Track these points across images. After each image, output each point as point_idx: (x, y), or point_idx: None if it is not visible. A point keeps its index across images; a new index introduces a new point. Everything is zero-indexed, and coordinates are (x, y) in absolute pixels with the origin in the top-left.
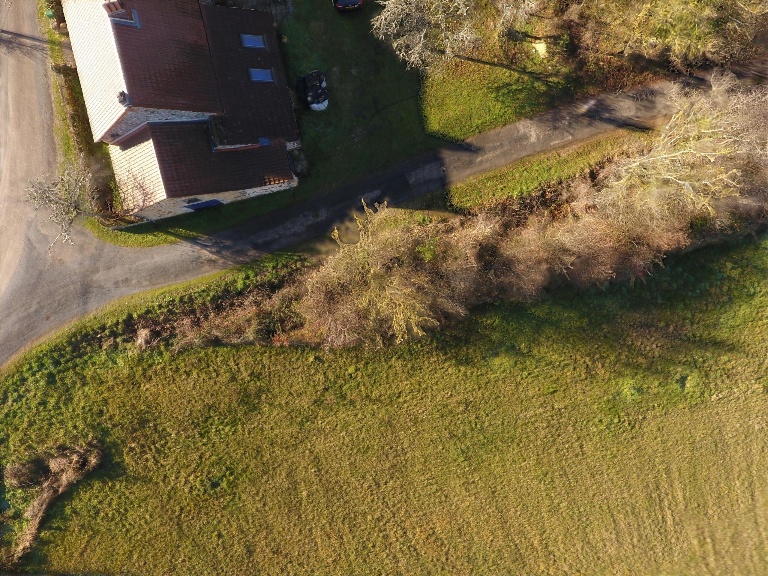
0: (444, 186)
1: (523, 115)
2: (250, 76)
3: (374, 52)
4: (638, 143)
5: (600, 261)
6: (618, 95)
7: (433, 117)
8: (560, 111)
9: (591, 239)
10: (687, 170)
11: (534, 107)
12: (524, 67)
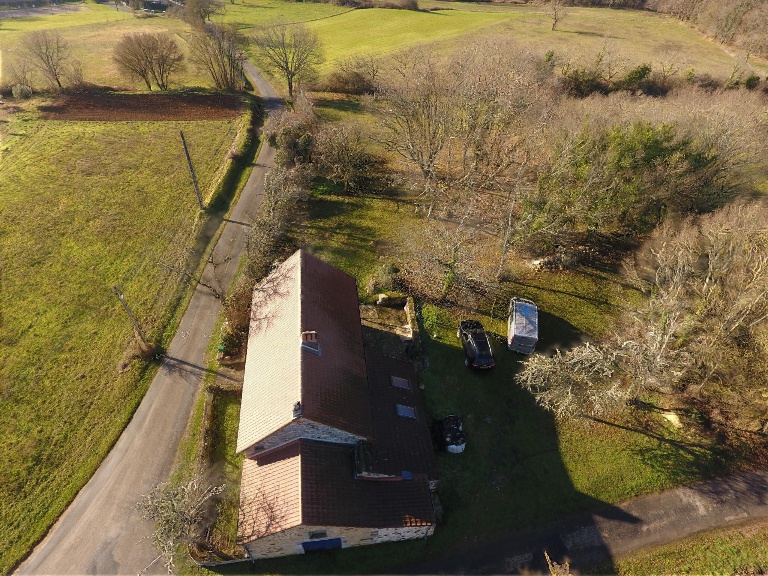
0: (611, 558)
1: (680, 482)
2: (397, 410)
3: (507, 406)
4: None
5: None
6: None
7: (580, 473)
8: (720, 482)
9: None
10: None
11: (689, 475)
12: (661, 434)
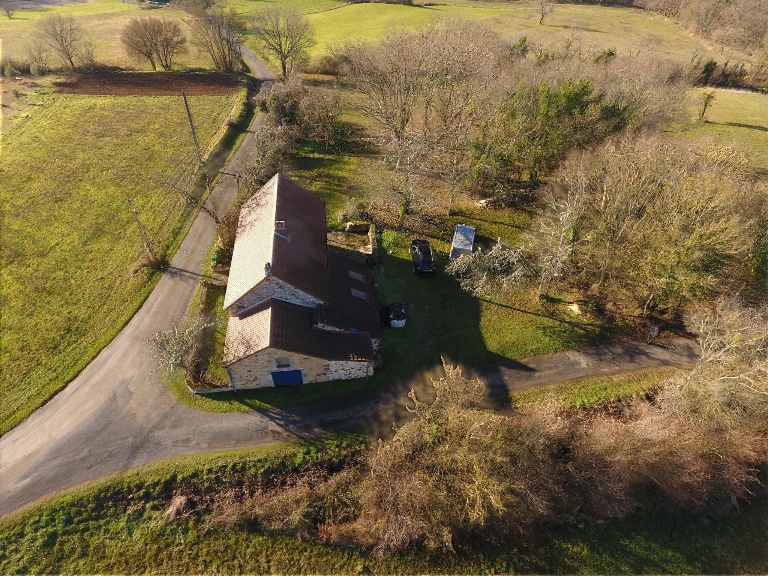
0: (508, 392)
1: (570, 347)
2: (351, 292)
3: (443, 299)
4: (682, 378)
5: (686, 460)
6: (649, 343)
7: (493, 340)
8: (602, 348)
9: (668, 433)
10: (735, 357)
11: (579, 343)
12: (563, 318)
